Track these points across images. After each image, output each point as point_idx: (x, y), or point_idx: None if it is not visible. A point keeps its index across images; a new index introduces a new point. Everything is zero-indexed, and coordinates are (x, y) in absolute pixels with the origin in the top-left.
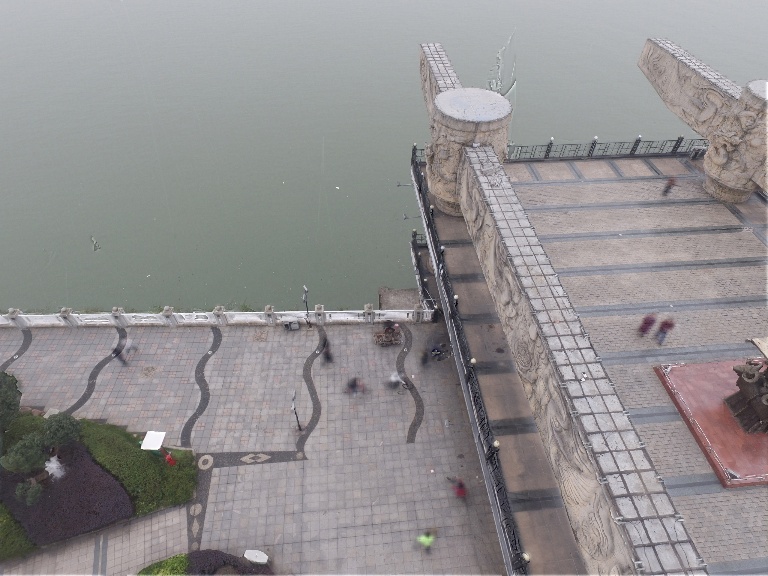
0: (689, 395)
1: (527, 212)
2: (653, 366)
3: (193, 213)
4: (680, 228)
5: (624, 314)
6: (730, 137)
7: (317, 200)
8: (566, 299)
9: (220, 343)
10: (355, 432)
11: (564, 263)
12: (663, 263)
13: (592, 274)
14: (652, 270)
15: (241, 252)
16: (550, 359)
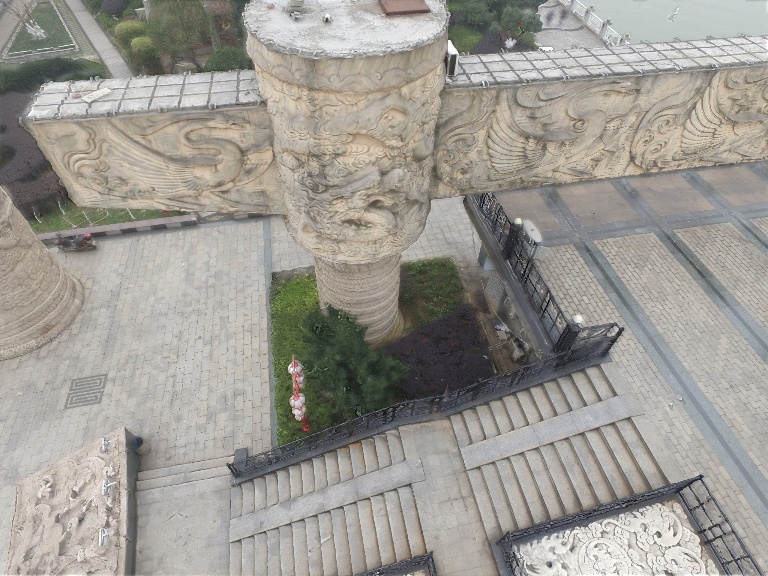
0: None
1: None
2: None
3: (758, 24)
4: None
5: None
6: None
7: None
8: None
9: None
10: None
11: None
12: None
13: None
14: None
15: None
16: None
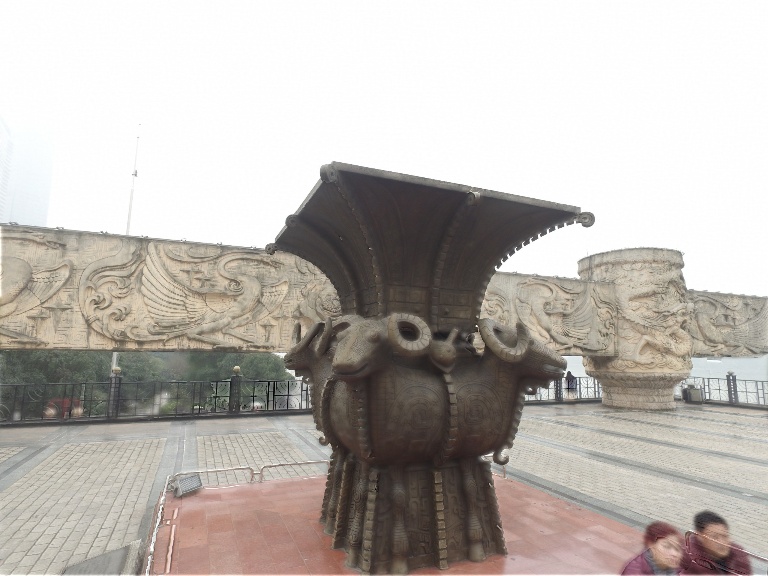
0: None
1: (730, 423)
2: None
3: None
4: None
5: (595, 458)
6: None
7: None
8: None
9: None
10: None
11: (649, 435)
12: None
13: None
14: None
15: None
16: None
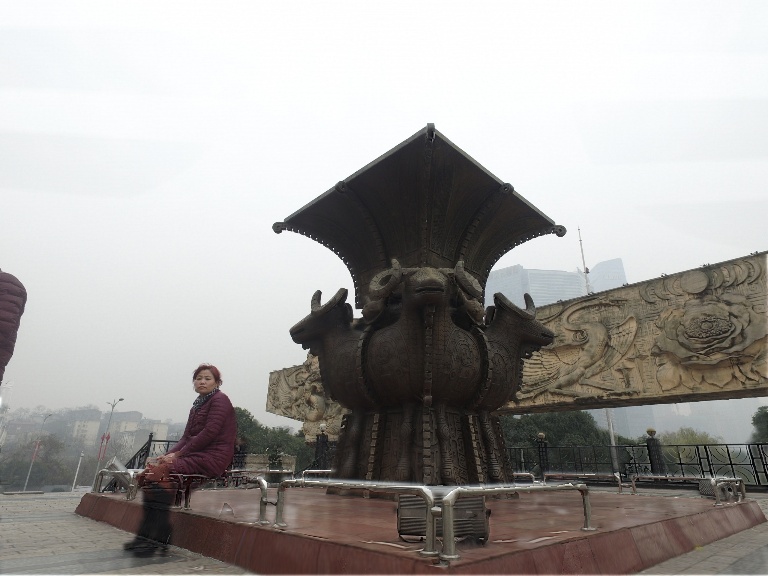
0: None
1: None
2: None
3: None
4: None
5: None
6: None
7: None
8: None
9: None
10: None
11: None
12: None
13: None
14: None
15: None
16: None
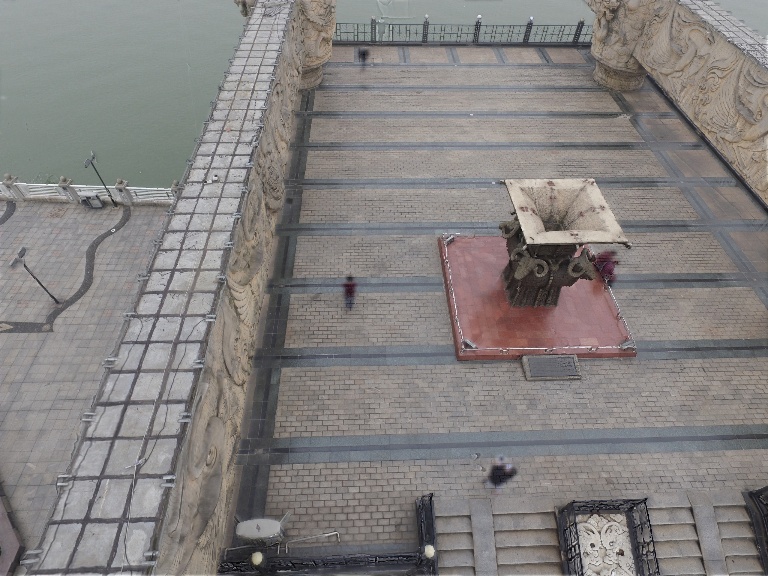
0: (463, 266)
1: (375, 90)
2: (438, 238)
3: (10, 82)
4: (545, 112)
5: (433, 187)
6: (608, 1)
7: (189, 94)
8: (260, 111)
9: (10, 217)
10: (118, 308)
11: (390, 138)
12: (506, 143)
13: (417, 149)
14: (490, 148)
15: (85, 139)
16: (187, 162)
